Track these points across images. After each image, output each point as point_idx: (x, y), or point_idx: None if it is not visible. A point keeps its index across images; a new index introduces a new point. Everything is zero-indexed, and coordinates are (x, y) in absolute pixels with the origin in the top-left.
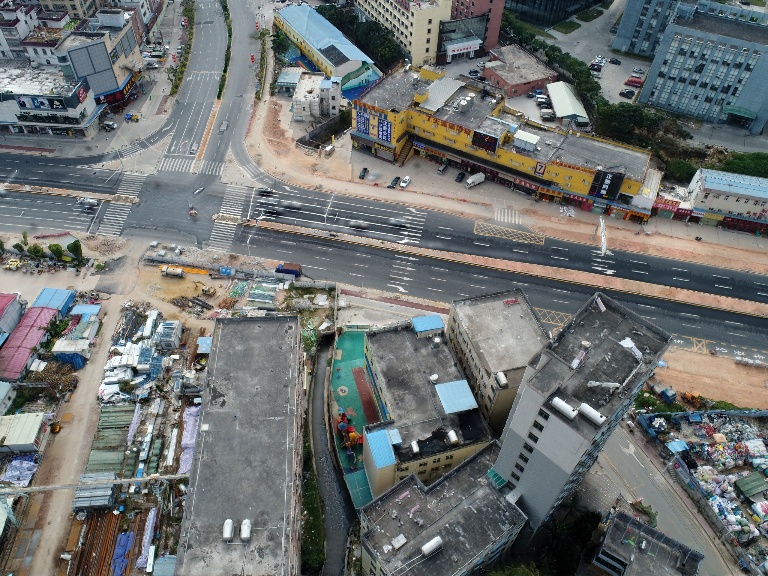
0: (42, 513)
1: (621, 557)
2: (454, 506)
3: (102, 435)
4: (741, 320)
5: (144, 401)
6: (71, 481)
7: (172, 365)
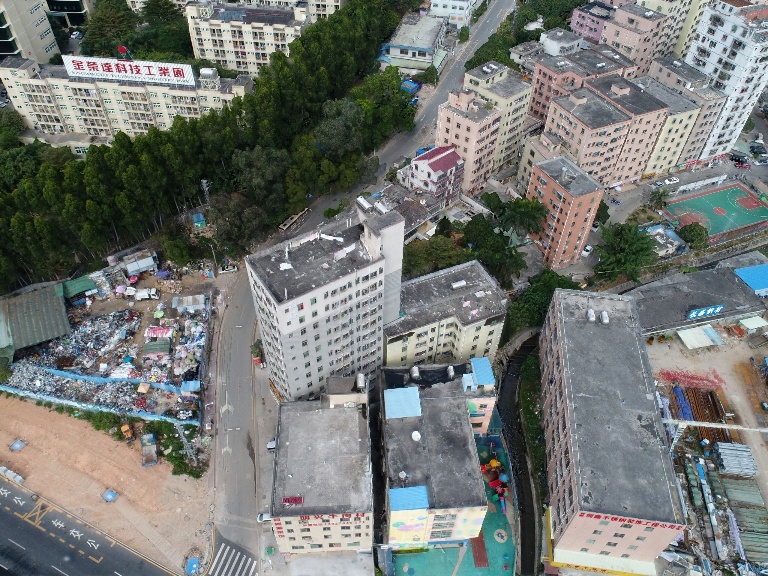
0: None
1: None
2: (436, 306)
3: (764, 524)
4: None
5: (739, 561)
6: (767, 480)
7: None
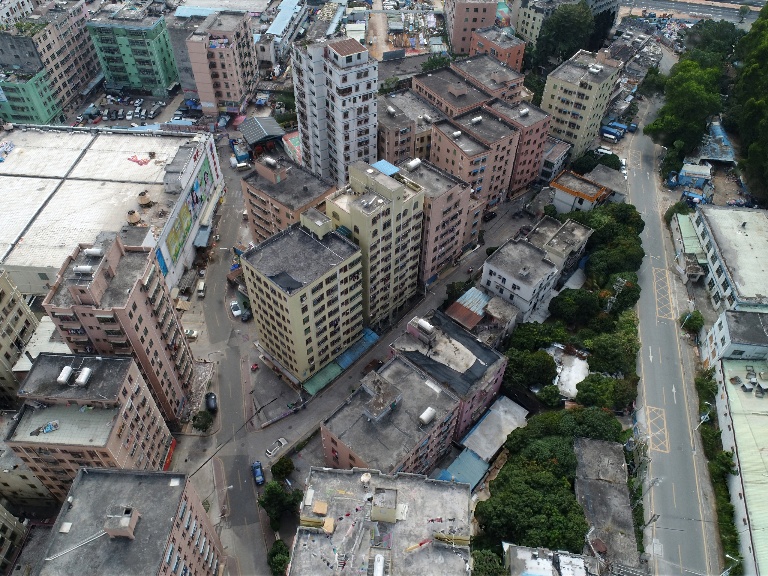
0: (375, 33)
1: (622, 30)
2: None
3: None
4: (696, 5)
5: None
6: None
7: (413, 5)
